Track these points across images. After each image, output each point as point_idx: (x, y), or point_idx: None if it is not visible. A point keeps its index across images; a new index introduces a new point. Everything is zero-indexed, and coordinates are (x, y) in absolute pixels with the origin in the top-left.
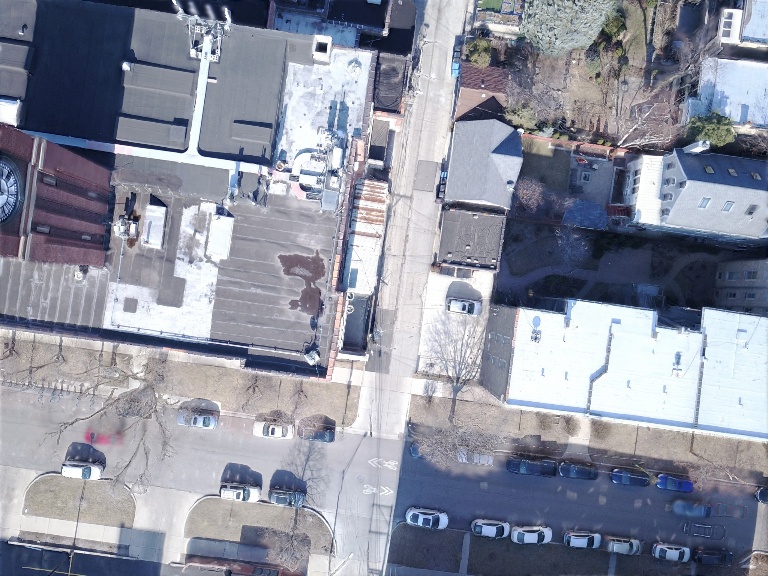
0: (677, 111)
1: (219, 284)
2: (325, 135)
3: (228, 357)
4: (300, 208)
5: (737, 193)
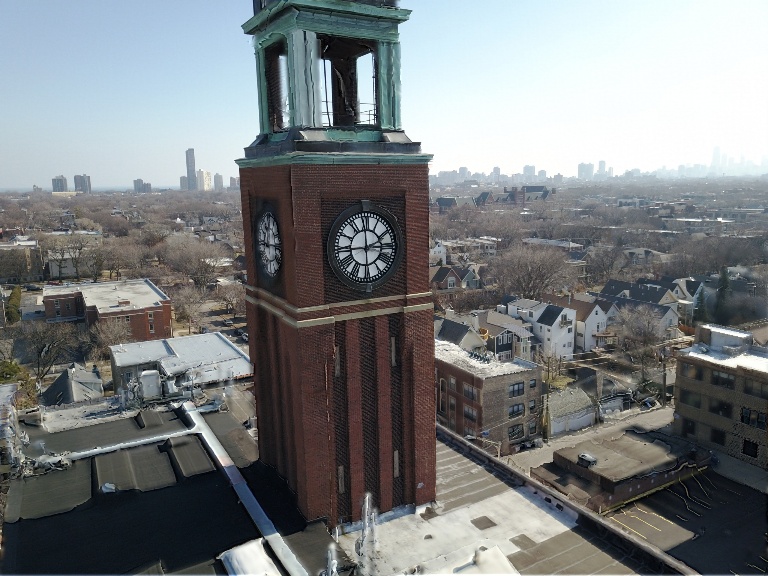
0: (1, 456)
1: None
2: None
3: None
4: None
5: (77, 391)
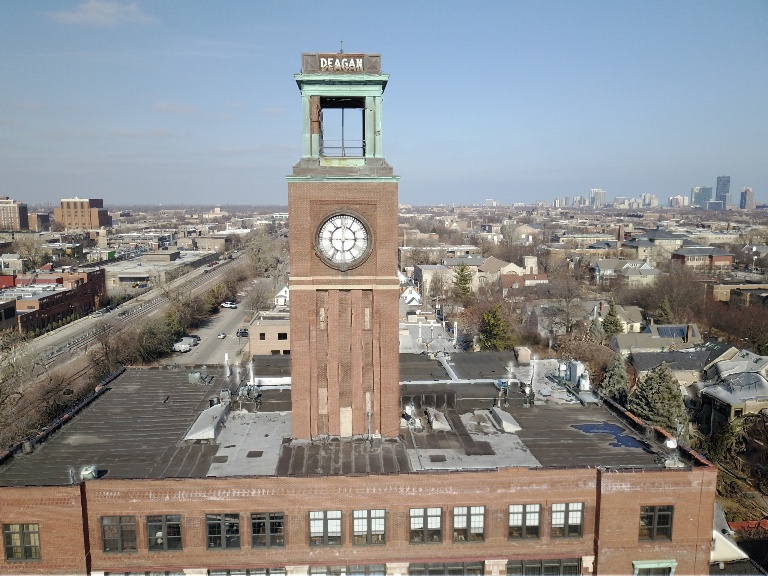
0: None
1: (525, 442)
2: (553, 384)
3: (580, 465)
4: (565, 407)
5: None
